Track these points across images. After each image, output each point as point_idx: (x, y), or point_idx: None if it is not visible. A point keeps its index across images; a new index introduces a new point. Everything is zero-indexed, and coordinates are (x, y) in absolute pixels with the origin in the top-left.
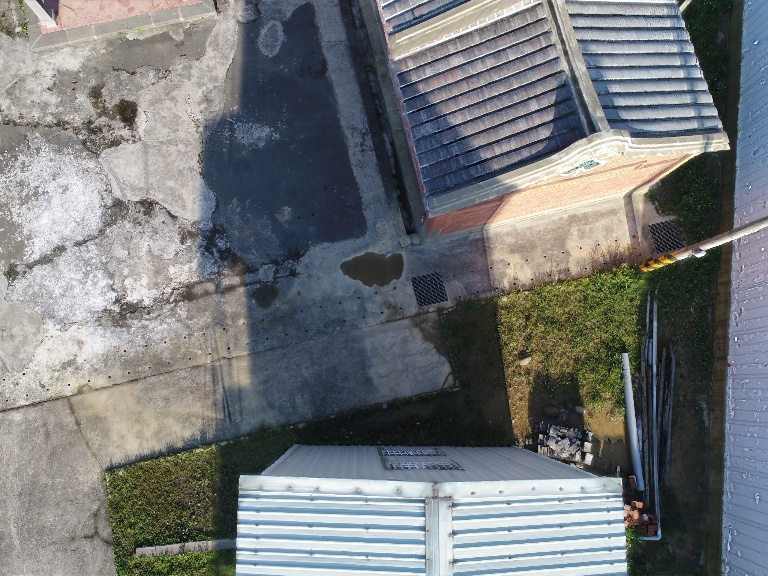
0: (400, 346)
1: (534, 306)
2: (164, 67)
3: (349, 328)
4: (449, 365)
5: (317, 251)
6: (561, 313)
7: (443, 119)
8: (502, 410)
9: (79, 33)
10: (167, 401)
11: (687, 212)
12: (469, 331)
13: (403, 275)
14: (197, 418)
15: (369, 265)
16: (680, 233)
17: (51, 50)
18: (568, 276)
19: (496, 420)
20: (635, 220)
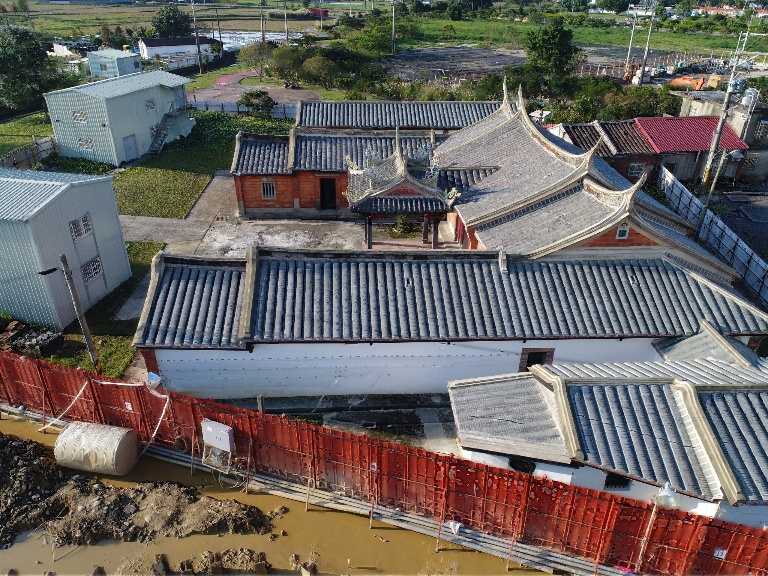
0: None
1: None
2: None
3: None
4: None
5: None
6: None
7: None
8: None
9: None
10: None
11: None
12: None
13: None
14: None
15: None
16: None
17: None
18: None
19: None
20: None
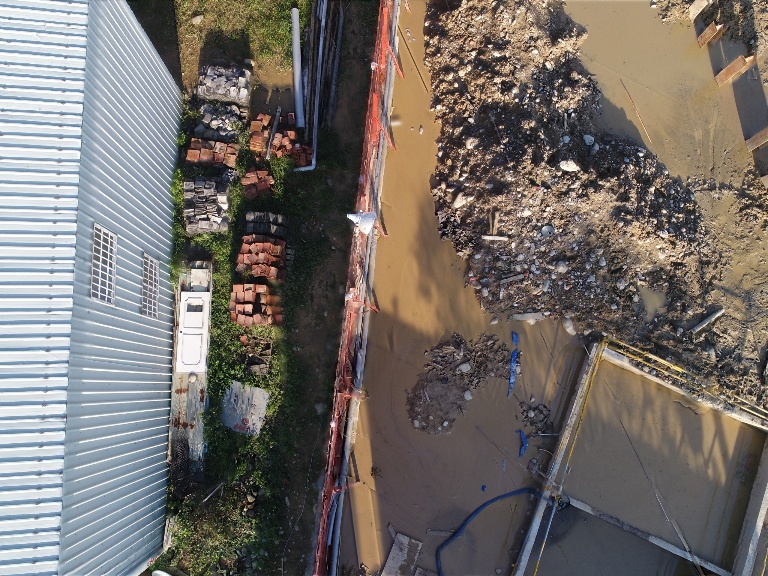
0: None
1: None
2: None
3: None
4: None
5: None
6: None
7: None
8: (173, 64)
9: None
10: None
11: None
12: None
13: None
14: None
15: None
16: None
17: None
18: None
19: None
20: None
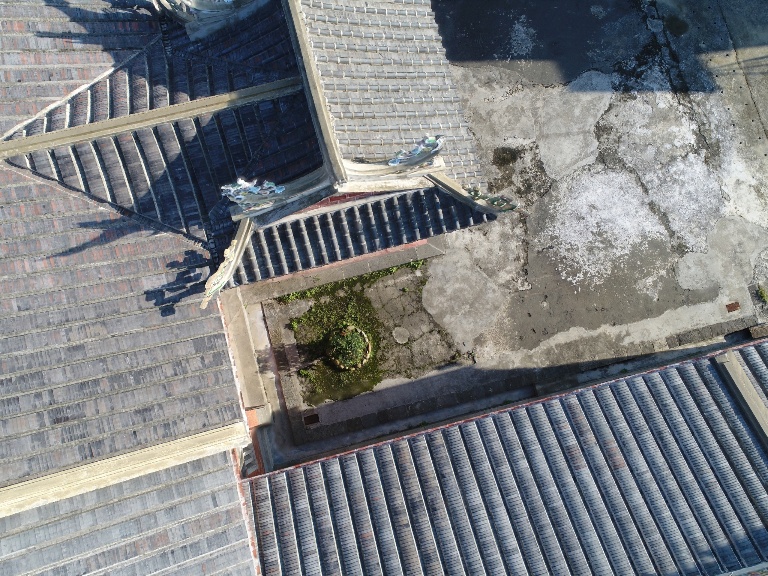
0: None
1: None
2: None
3: None
4: None
5: None
6: None
7: None
8: None
9: None
10: None
11: None
12: None
13: None
14: None
15: None
16: None
17: (442, 236)
18: None
19: None
20: None
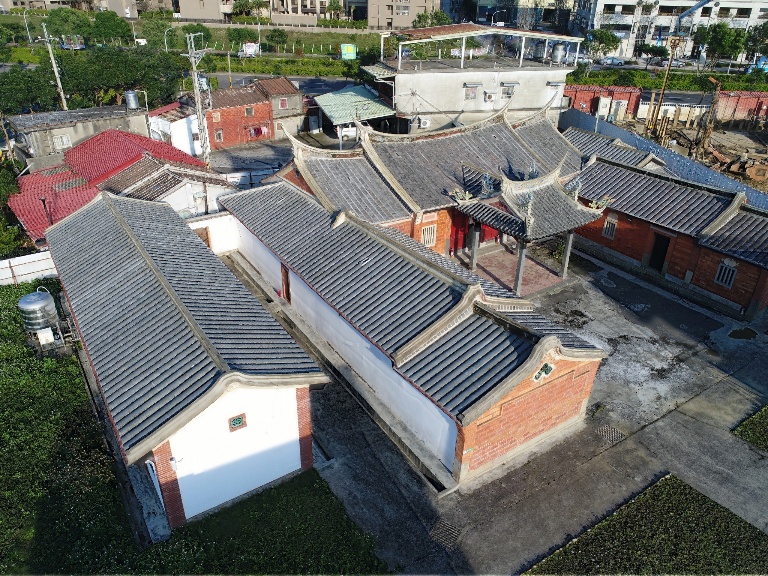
0: None
1: None
2: (576, 298)
3: (762, 353)
4: None
5: (713, 334)
6: None
7: (743, 246)
8: None
9: (531, 295)
10: (722, 398)
11: None
12: None
13: (758, 333)
14: (744, 400)
15: (740, 333)
16: None
17: None
18: None
19: None
20: None
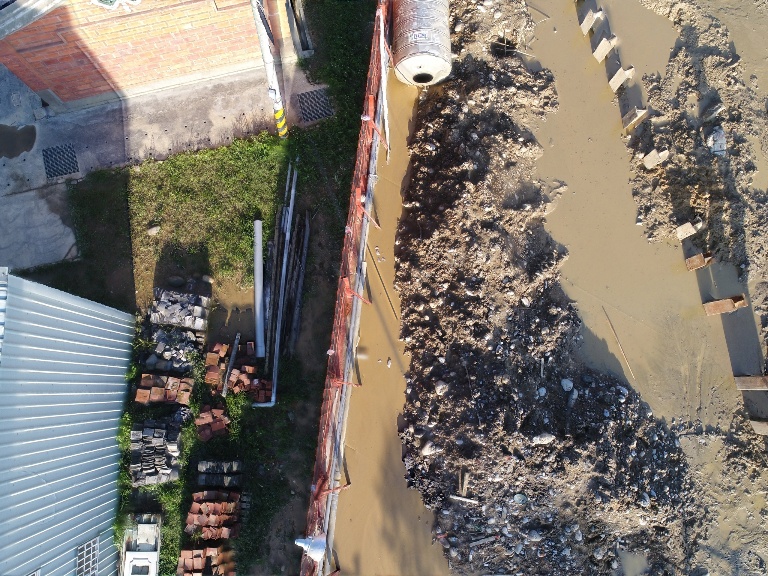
0: (24, 218)
1: (168, 175)
2: None
3: None
4: (74, 236)
5: None
6: (196, 182)
7: None
8: (126, 280)
9: None
10: None
11: (333, 78)
12: (97, 201)
13: (34, 147)
14: None
15: None
16: (330, 101)
17: None
18: (208, 146)
19: (118, 290)
20: (284, 89)
